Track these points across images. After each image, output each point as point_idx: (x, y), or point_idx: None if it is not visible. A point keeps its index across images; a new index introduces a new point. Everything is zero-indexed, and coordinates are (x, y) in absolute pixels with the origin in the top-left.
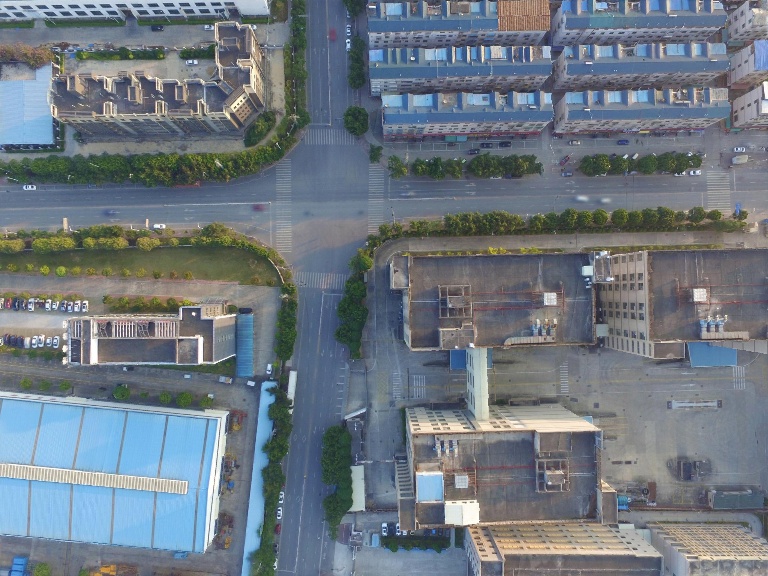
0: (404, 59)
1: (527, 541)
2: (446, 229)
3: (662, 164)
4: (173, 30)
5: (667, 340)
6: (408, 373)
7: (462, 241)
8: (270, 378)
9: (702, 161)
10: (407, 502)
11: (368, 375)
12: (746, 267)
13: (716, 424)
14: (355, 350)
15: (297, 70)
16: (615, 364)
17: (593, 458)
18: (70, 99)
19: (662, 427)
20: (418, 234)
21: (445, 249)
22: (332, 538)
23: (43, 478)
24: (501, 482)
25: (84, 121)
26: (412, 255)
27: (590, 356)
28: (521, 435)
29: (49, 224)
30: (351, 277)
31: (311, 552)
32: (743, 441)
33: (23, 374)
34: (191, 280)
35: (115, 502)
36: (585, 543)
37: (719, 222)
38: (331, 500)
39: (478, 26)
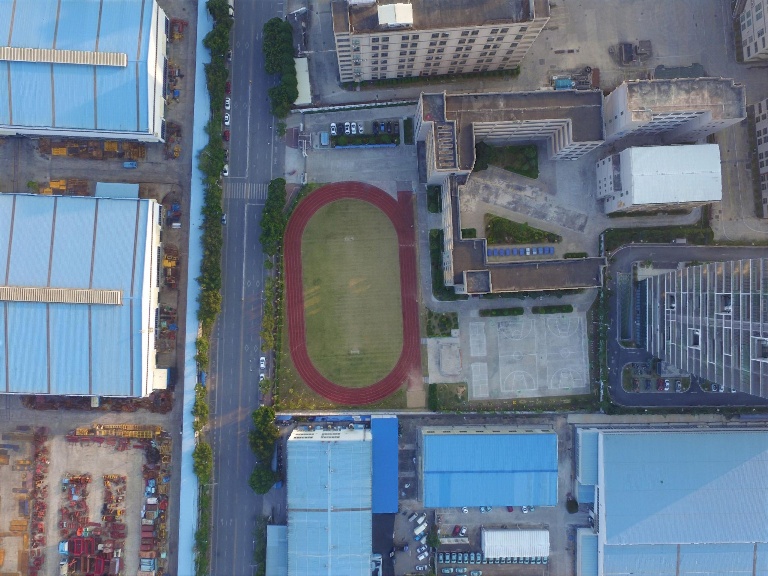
0: None
1: None
2: None
3: None
4: None
5: None
6: None
7: None
8: None
9: None
10: (340, 5)
11: None
12: None
13: (655, 9)
14: None
15: None
16: None
17: None
18: None
19: (602, 15)
20: None
21: None
22: (280, 134)
23: None
24: None
25: None
26: None
27: None
28: None
29: None
30: None
31: (262, 158)
32: (682, 24)
33: None
34: None
35: (54, 81)
36: None
37: None
38: (275, 87)
39: None
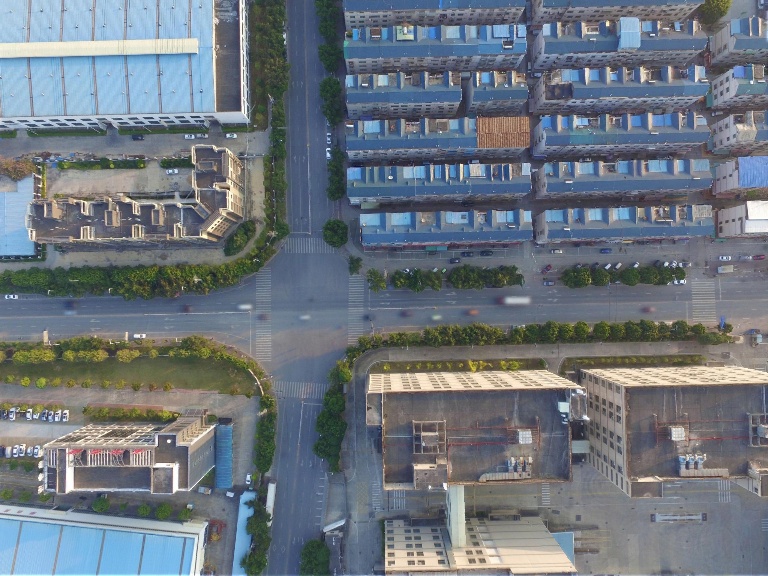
0: (382, 178)
1: None
2: (426, 341)
3: (645, 278)
4: (154, 139)
5: (645, 476)
6: None
7: (442, 351)
8: (249, 488)
9: (687, 270)
10: None
11: (347, 486)
12: (726, 402)
13: (701, 538)
14: (333, 464)
15: (276, 182)
16: (597, 476)
17: None
18: (48, 221)
19: (645, 540)
20: (398, 344)
21: (425, 359)
22: None
23: None
24: None
25: (62, 242)
26: (392, 365)
27: (572, 468)
28: (496, 572)
29: (30, 333)
30: (330, 389)
31: None
32: (728, 555)
33: (4, 483)
34: (171, 389)
35: None
36: None
37: (703, 336)
38: None
39: (457, 144)
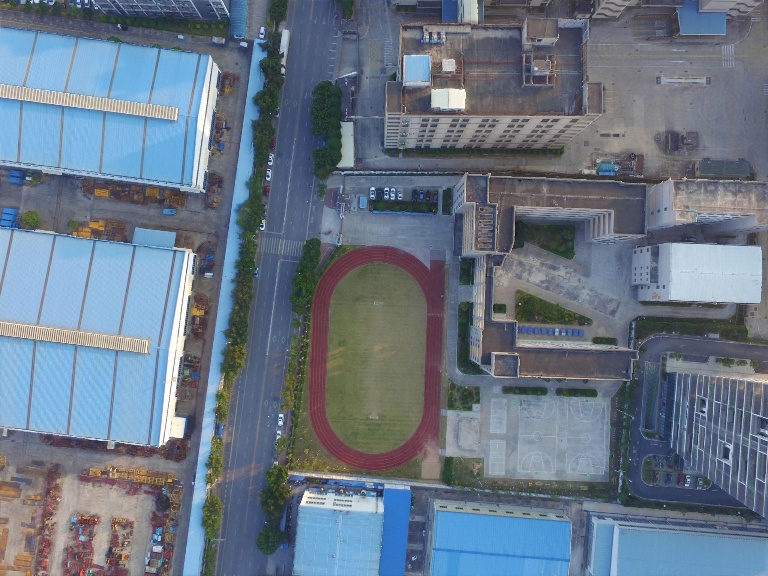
0: None
1: None
2: None
3: None
4: None
5: None
6: None
7: None
8: None
9: None
10: (394, 85)
11: (360, 42)
12: None
13: (704, 100)
14: (348, 5)
15: None
16: (605, 39)
17: (580, 57)
18: None
19: (651, 102)
20: None
21: None
22: (320, 195)
23: (35, 98)
24: (488, 76)
25: None
26: None
27: None
28: (509, 33)
29: None
30: None
31: (299, 215)
32: (731, 118)
33: None
34: None
35: (105, 128)
36: None
37: None
38: (320, 149)
39: None
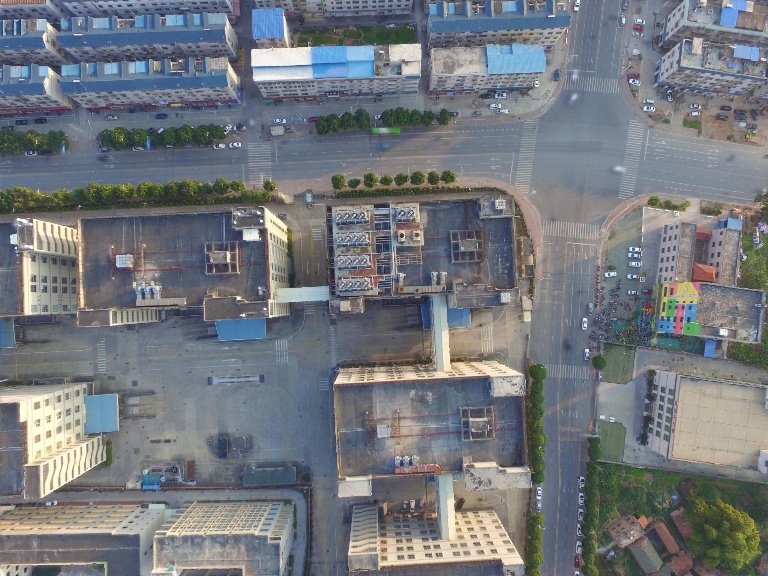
0: None
1: (23, 523)
2: None
3: (179, 136)
4: None
5: (104, 308)
6: None
7: None
8: None
9: (243, 133)
10: None
11: None
12: (186, 232)
13: (258, 399)
14: None
15: None
16: (154, 340)
17: None
18: None
19: (202, 404)
20: None
21: None
22: None
23: None
24: None
25: None
26: None
27: (128, 333)
28: None
29: None
30: None
31: None
32: (286, 416)
33: None
34: None
35: None
36: (80, 523)
37: (243, 193)
38: None
39: None
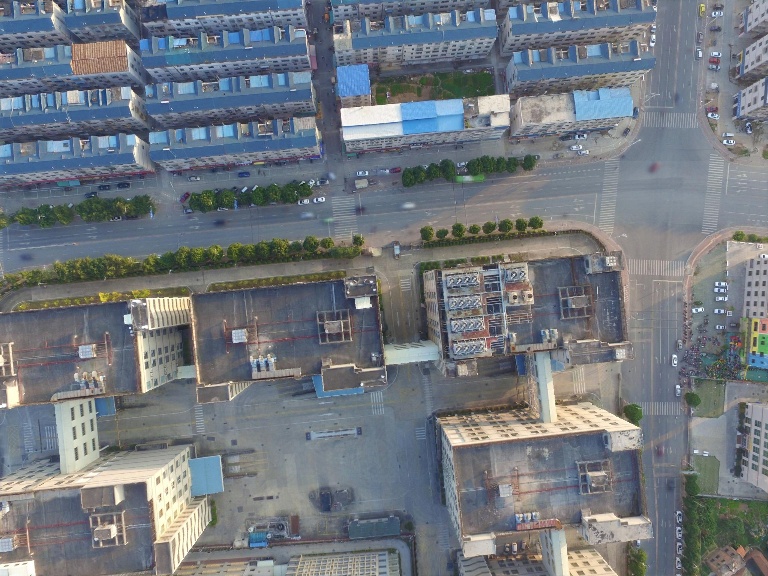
0: None
1: None
2: None
3: (267, 196)
4: None
5: (220, 383)
6: (39, 425)
7: (86, 286)
8: None
9: (326, 188)
10: None
11: None
12: (297, 302)
13: (357, 452)
14: None
15: None
16: (250, 399)
17: None
18: None
19: (302, 459)
20: (37, 283)
21: (69, 296)
22: None
23: None
24: (57, 540)
25: None
26: (35, 305)
27: None
28: (77, 491)
29: None
30: None
31: None
32: (385, 467)
33: None
34: None
35: None
36: None
37: (333, 250)
38: None
39: (52, 72)
